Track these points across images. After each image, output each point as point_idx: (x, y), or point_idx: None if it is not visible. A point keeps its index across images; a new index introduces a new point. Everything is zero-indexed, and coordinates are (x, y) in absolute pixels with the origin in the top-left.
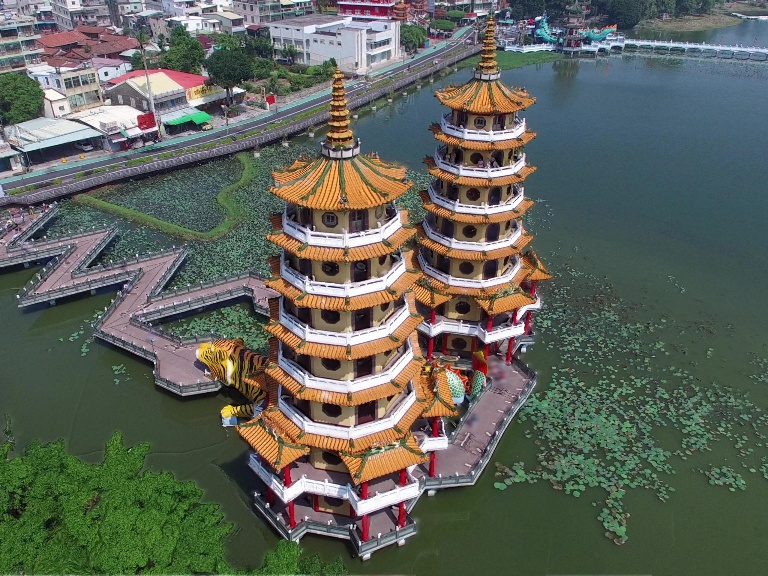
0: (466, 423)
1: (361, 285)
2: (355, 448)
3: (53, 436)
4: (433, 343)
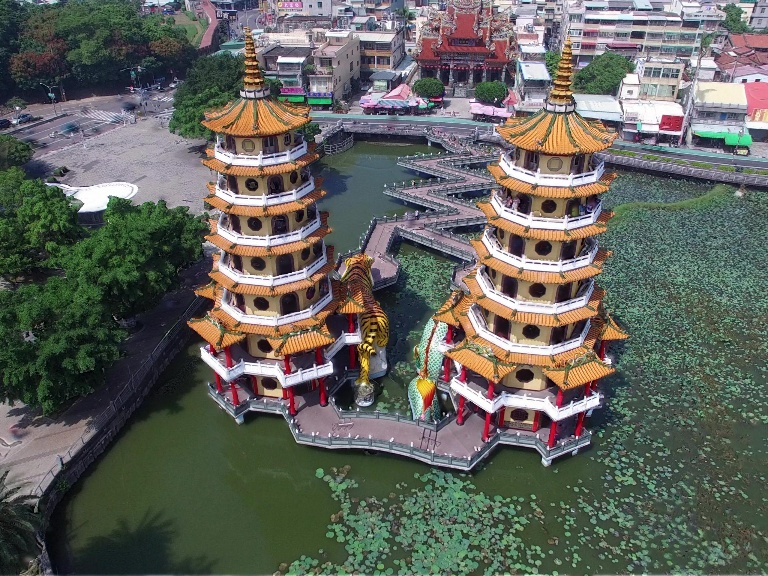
0: (365, 419)
1: (223, 192)
2: (215, 312)
3: None
4: None
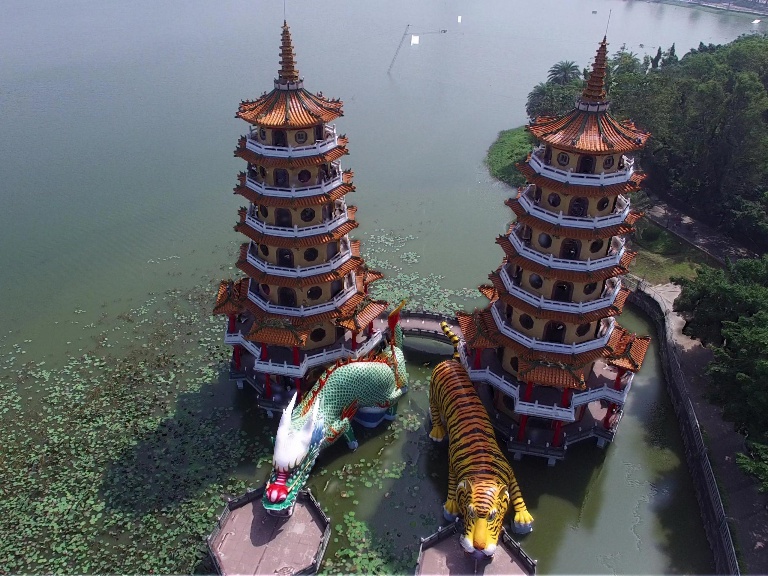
0: None
1: None
2: None
3: None
4: (372, 350)
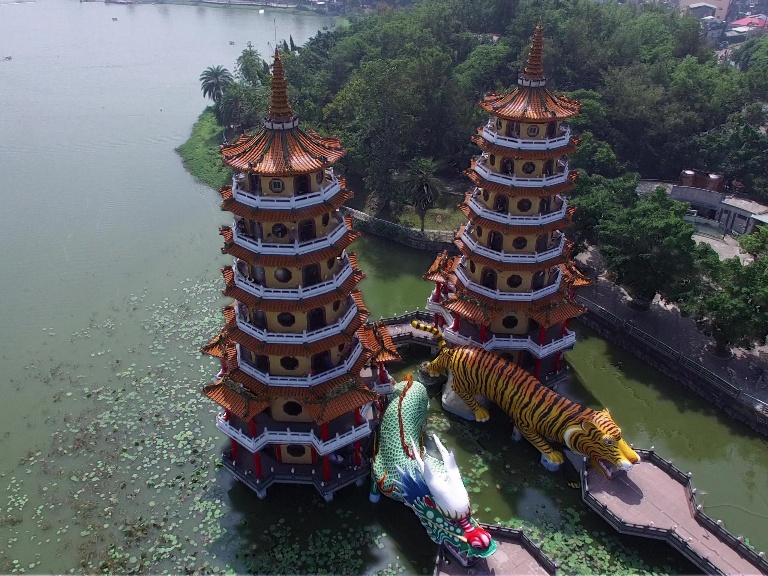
0: None
1: None
2: None
3: None
4: None
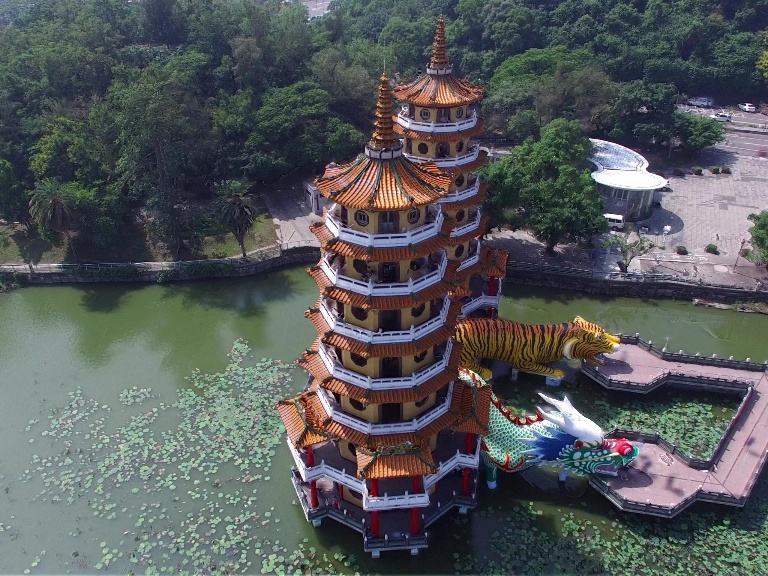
0: None
1: None
2: None
3: (681, 342)
4: None
